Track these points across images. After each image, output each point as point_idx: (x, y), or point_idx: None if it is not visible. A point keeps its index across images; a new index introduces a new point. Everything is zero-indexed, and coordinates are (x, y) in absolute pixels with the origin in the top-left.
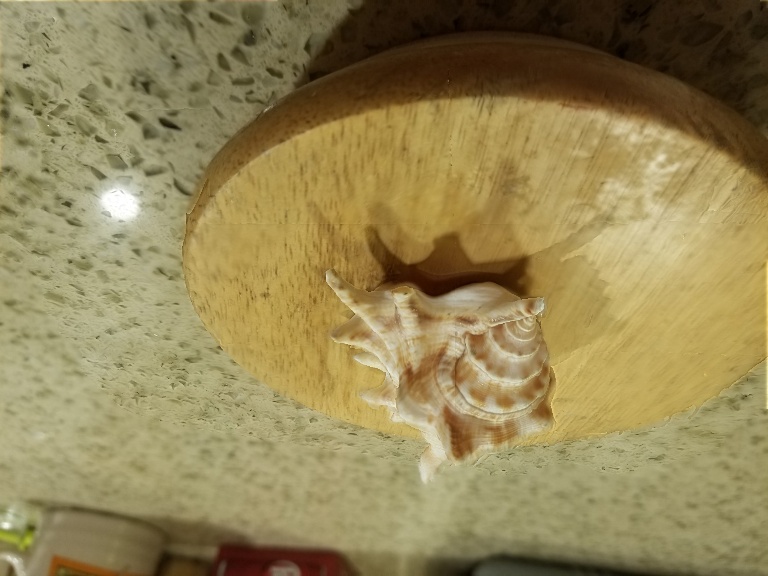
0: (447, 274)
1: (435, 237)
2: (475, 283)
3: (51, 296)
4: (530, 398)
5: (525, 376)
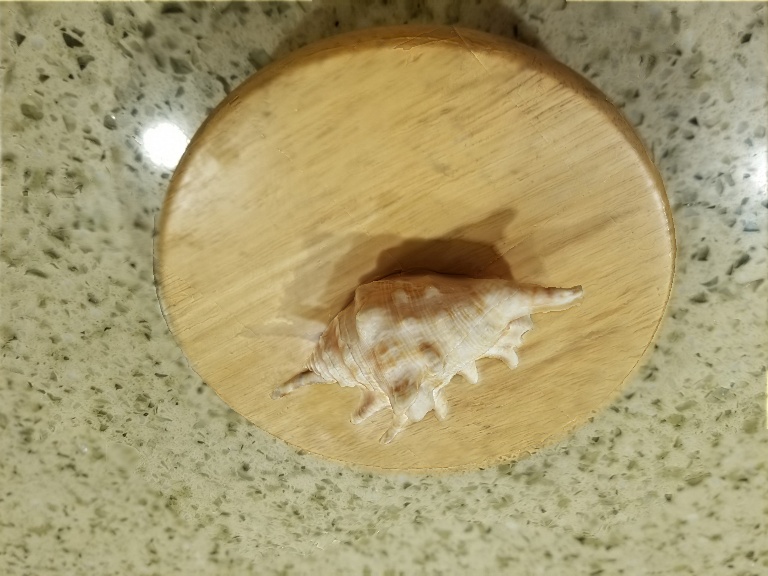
0: None
1: (338, 385)
2: None
3: (749, 427)
4: (342, 355)
5: None
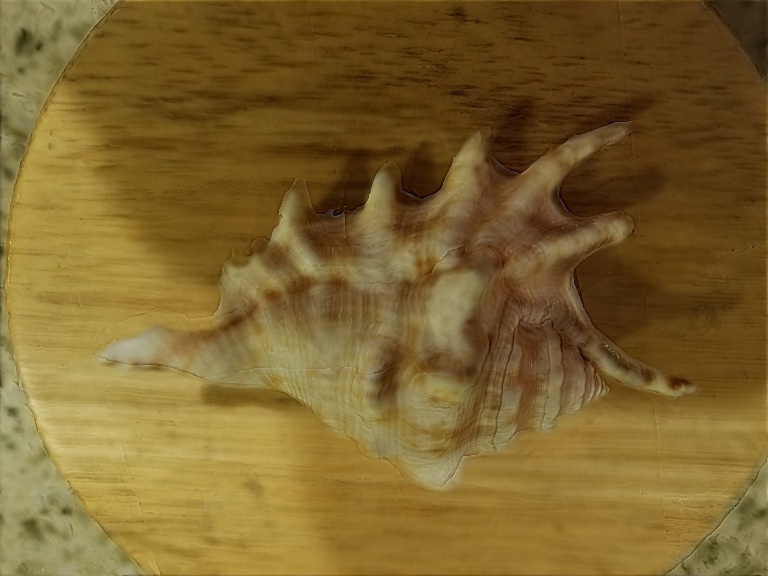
0: None
1: (618, 248)
2: None
3: None
4: None
5: None
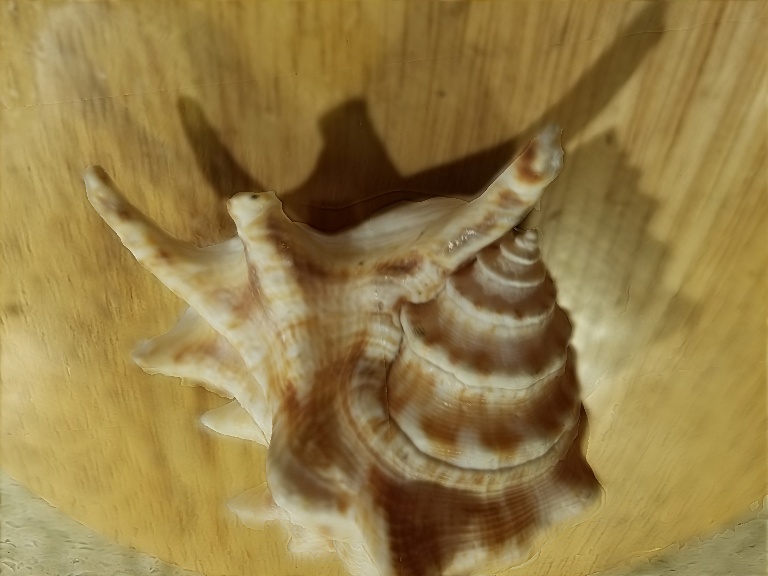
0: (354, 203)
1: (319, 111)
2: (408, 201)
3: None
4: (551, 428)
5: (536, 369)
